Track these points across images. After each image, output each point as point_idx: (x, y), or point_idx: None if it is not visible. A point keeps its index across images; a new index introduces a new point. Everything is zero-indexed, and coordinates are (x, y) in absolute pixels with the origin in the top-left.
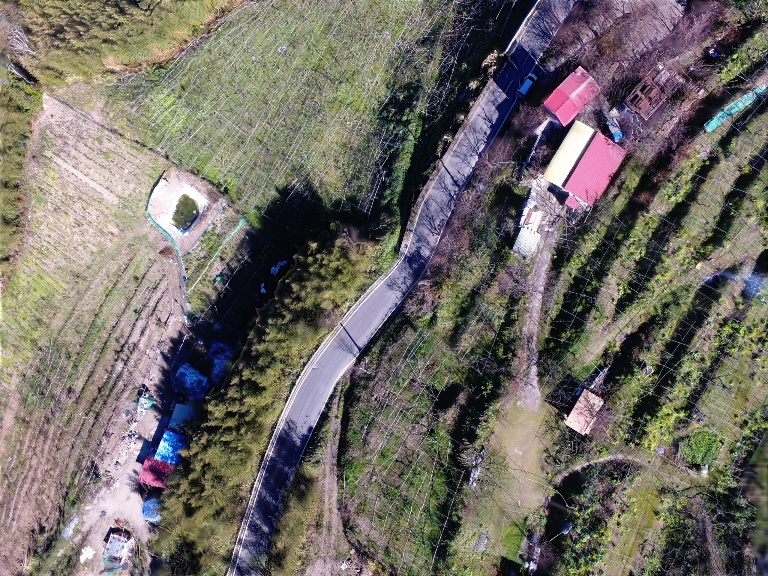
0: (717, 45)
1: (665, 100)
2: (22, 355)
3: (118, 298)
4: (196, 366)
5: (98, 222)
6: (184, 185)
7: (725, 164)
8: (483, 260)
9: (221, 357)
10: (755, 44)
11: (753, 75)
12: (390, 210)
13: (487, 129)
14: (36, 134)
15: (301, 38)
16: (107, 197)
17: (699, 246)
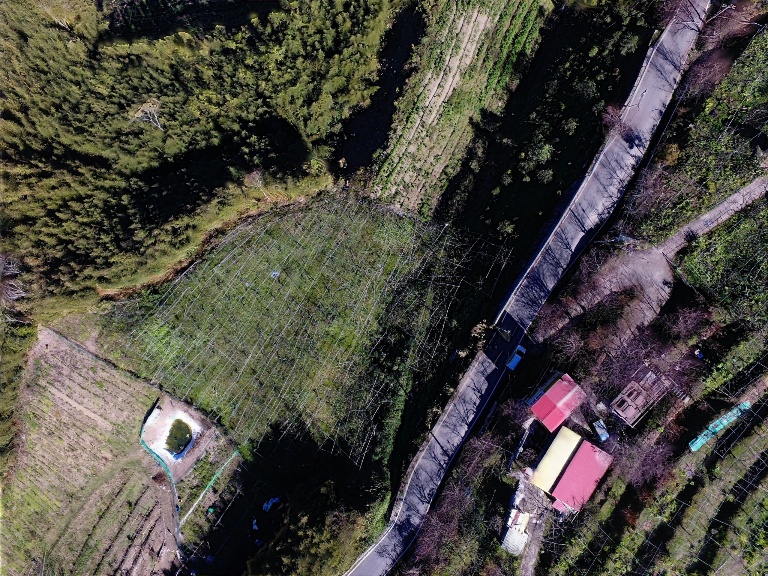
0: (702, 346)
1: (651, 408)
2: (16, 564)
3: (111, 522)
4: None
5: (92, 448)
6: (177, 411)
7: (709, 491)
8: (472, 545)
9: None
10: (739, 353)
11: (737, 393)
12: (381, 470)
13: (476, 399)
14: (31, 363)
15: (294, 264)
16: (101, 424)
17: (684, 570)
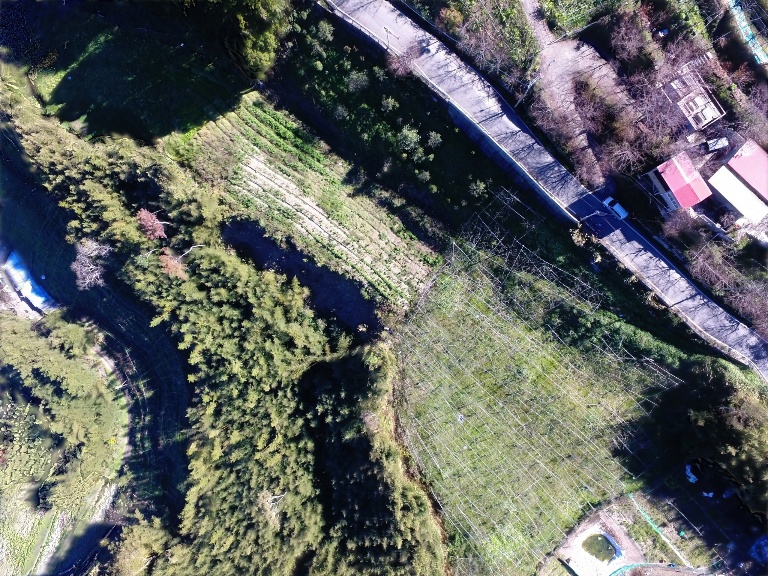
0: (656, 28)
1: (710, 92)
2: None
3: None
4: (765, 575)
5: None
6: (574, 543)
7: None
8: None
9: (765, 550)
10: None
11: (718, 6)
12: (692, 363)
13: (647, 255)
14: None
15: None
16: None
17: None
